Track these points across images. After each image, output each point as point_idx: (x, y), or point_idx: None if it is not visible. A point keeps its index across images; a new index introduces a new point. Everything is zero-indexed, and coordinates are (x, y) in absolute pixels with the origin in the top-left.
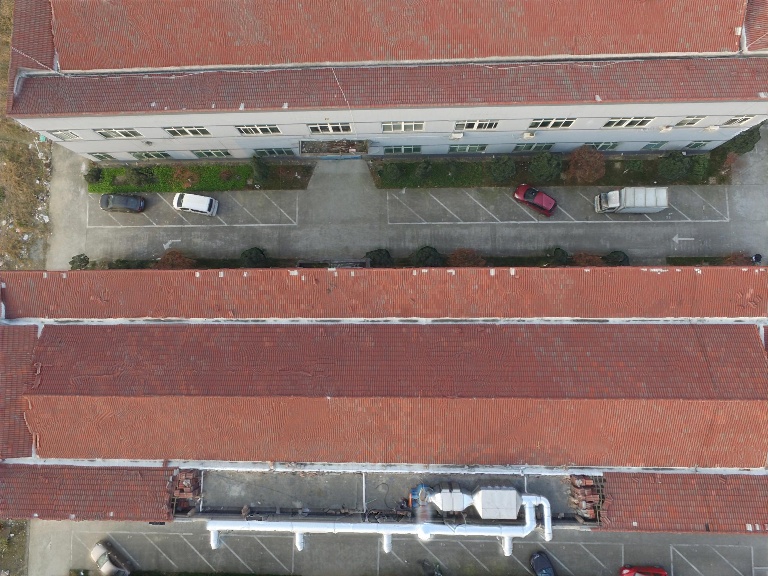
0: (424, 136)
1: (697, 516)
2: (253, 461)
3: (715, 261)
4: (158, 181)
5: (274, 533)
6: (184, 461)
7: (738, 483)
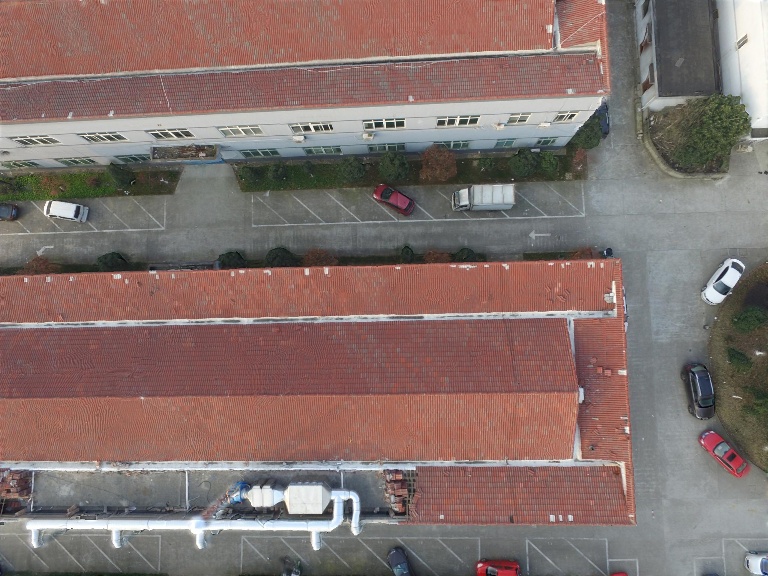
0: (270, 139)
1: (503, 508)
2: (81, 461)
3: (569, 256)
4: (32, 189)
5: None
6: (16, 462)
7: (546, 475)
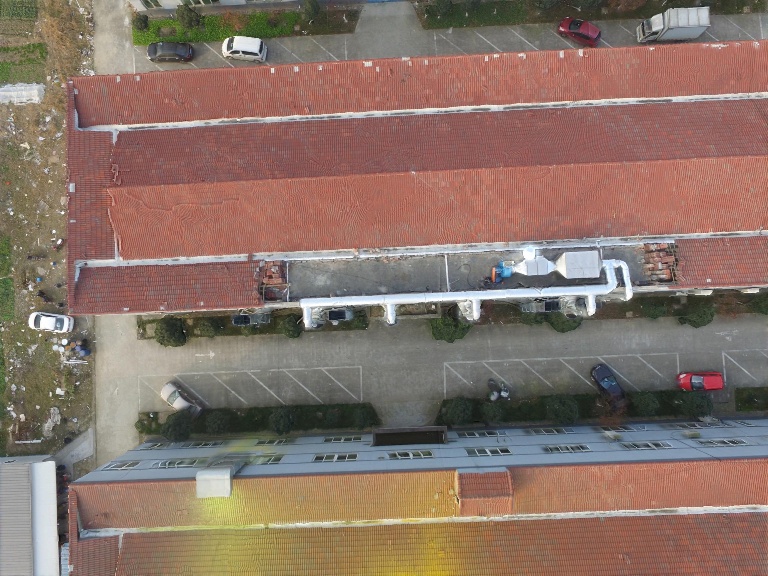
0: None
1: (765, 270)
2: (337, 249)
3: None
4: (204, 31)
5: (341, 364)
6: (268, 255)
7: None
